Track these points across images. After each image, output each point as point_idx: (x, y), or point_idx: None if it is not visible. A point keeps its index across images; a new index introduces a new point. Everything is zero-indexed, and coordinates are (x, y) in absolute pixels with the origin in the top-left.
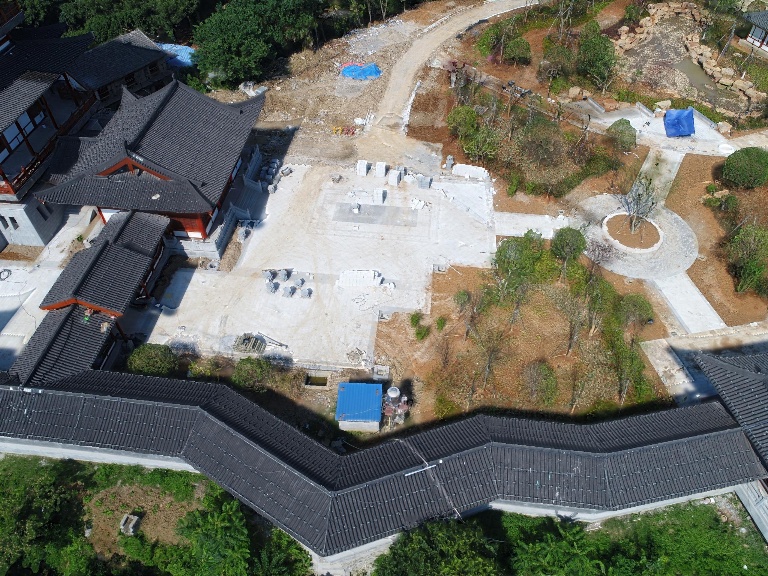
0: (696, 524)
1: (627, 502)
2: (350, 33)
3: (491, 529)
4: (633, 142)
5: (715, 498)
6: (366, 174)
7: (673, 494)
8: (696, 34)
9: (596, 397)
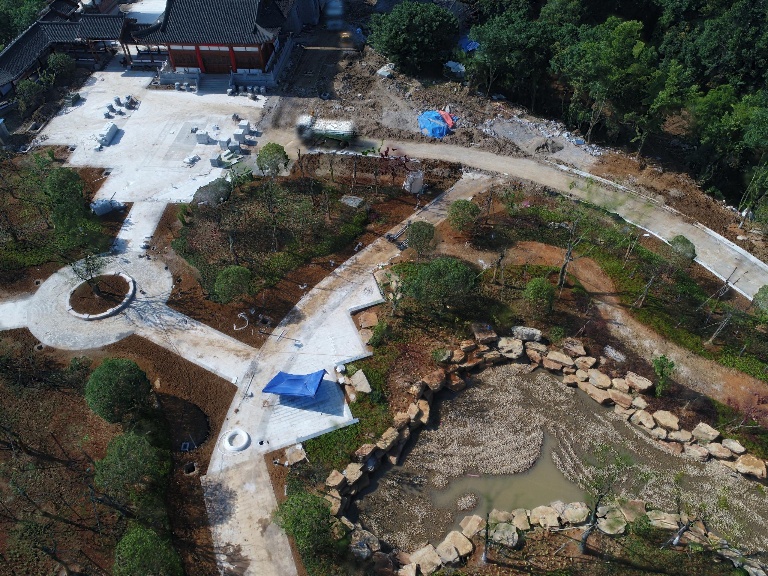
0: None
1: None
2: (550, 121)
3: None
4: None
5: None
6: None
7: None
8: (697, 534)
9: None
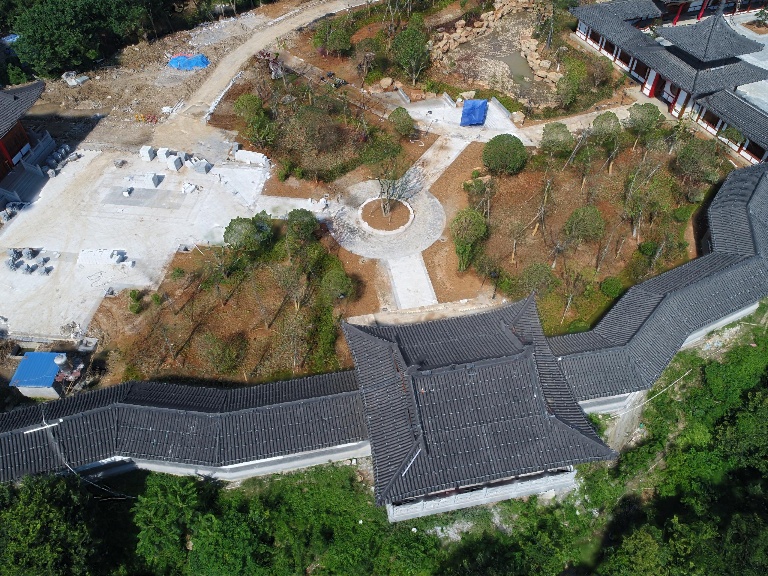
0: (331, 483)
1: (233, 459)
2: (199, 26)
3: (133, 487)
4: (410, 130)
5: (359, 460)
6: (151, 159)
7: (279, 452)
8: (532, 28)
9: (278, 367)
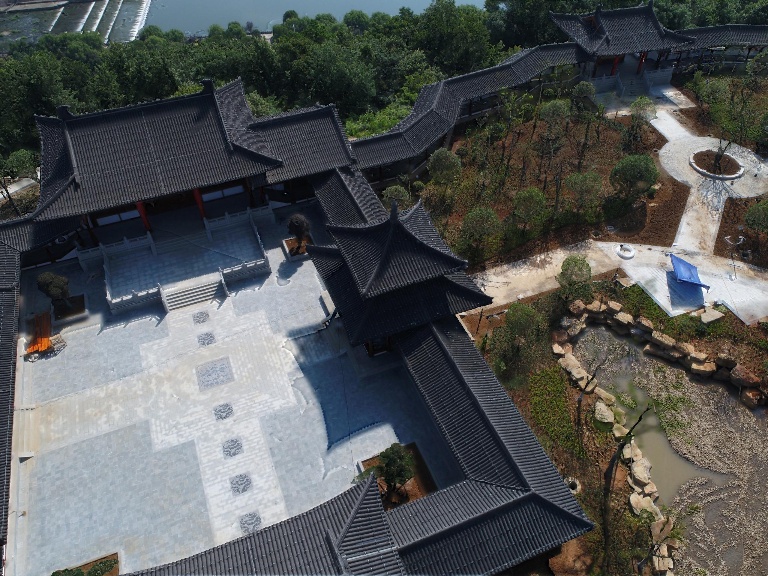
0: None
1: None
2: None
3: None
4: None
5: None
6: None
7: None
8: None
9: None
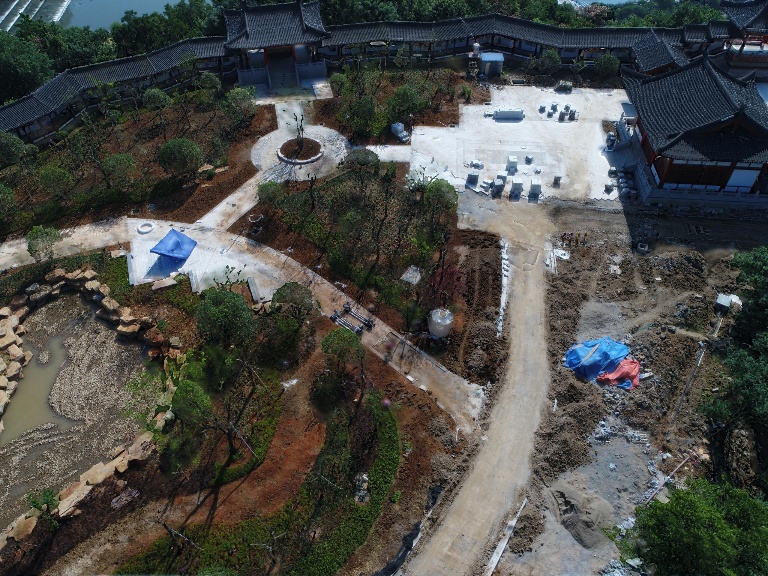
0: None
1: None
2: None
3: None
4: None
5: None
6: None
7: None
8: None
9: None
